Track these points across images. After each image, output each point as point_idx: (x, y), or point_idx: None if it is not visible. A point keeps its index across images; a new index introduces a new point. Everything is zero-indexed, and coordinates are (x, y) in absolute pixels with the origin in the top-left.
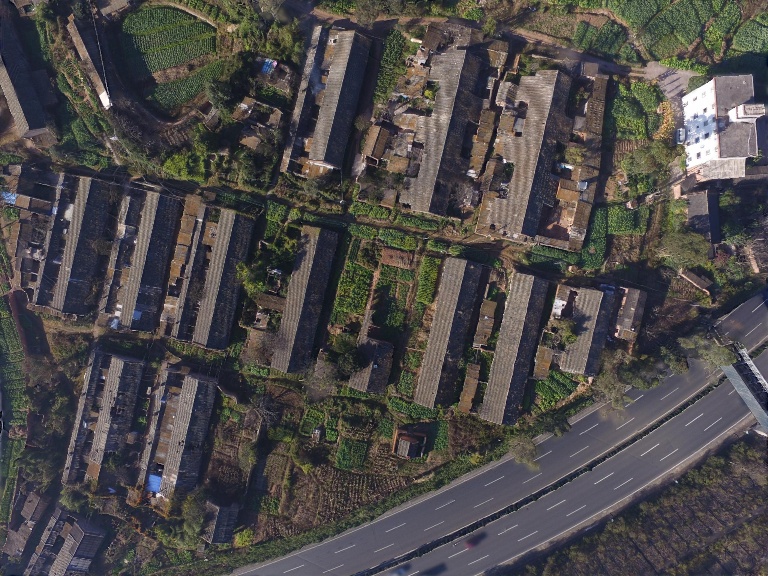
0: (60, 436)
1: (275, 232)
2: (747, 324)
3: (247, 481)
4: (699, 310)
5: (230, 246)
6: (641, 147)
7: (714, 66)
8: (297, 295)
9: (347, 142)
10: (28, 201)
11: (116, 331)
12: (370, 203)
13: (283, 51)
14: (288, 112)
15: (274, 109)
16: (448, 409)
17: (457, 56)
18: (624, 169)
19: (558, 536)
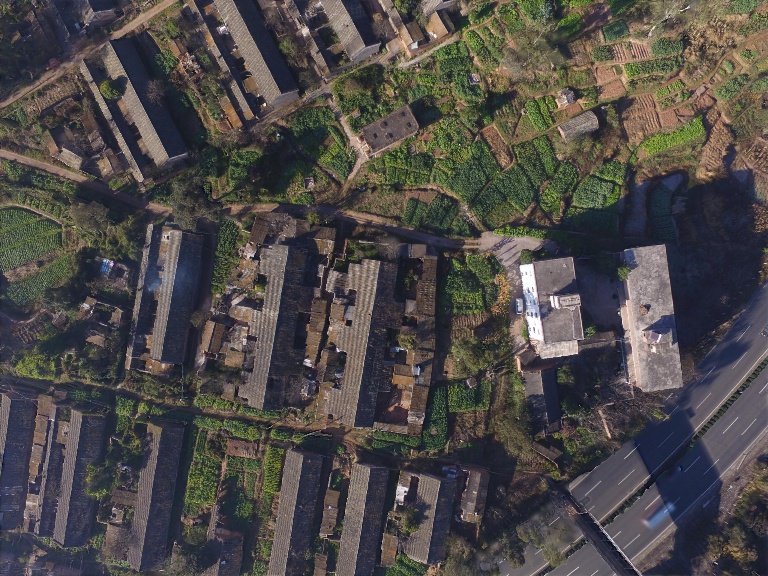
0: None
1: (126, 425)
2: (620, 471)
3: None
4: (551, 480)
5: (80, 447)
6: (461, 341)
7: (553, 228)
8: (145, 493)
9: (189, 333)
10: None
11: None
12: (211, 397)
13: (119, 250)
14: (129, 308)
15: (115, 307)
16: None
17: (281, 251)
18: (454, 355)
19: None
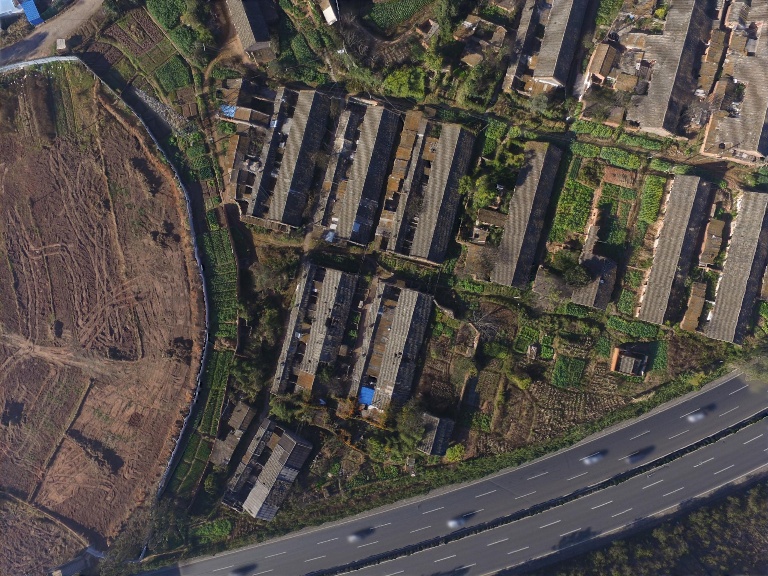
0: (269, 348)
1: (493, 150)
2: None
3: (462, 395)
4: None
5: (454, 160)
6: None
7: None
8: (522, 209)
9: None
10: (249, 113)
11: (331, 244)
12: (596, 120)
13: None
14: (511, 31)
15: (498, 27)
16: (668, 329)
17: None
18: None
19: (755, 470)
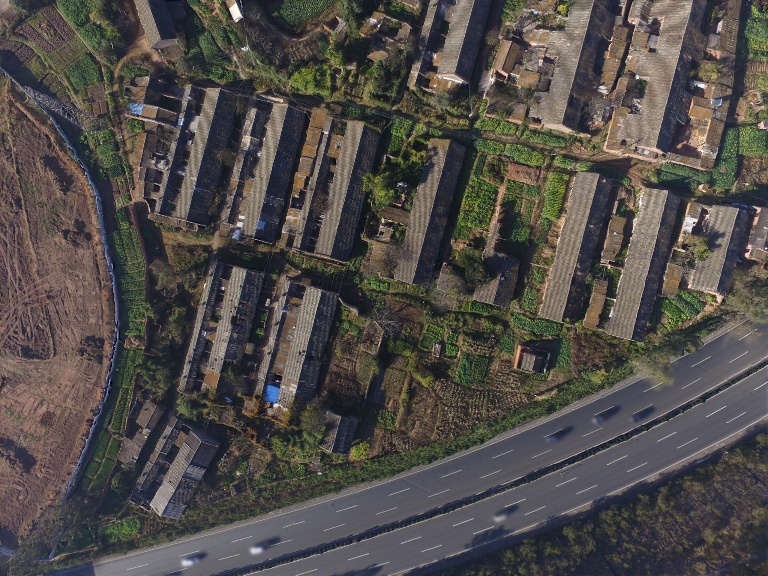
0: (177, 346)
1: (399, 147)
2: None
3: (366, 393)
4: None
5: (357, 157)
6: None
7: None
8: (424, 207)
9: None
10: (155, 111)
11: (238, 242)
12: (499, 117)
13: None
14: (416, 28)
15: (403, 24)
16: (571, 327)
17: None
18: (761, 86)
19: (669, 468)
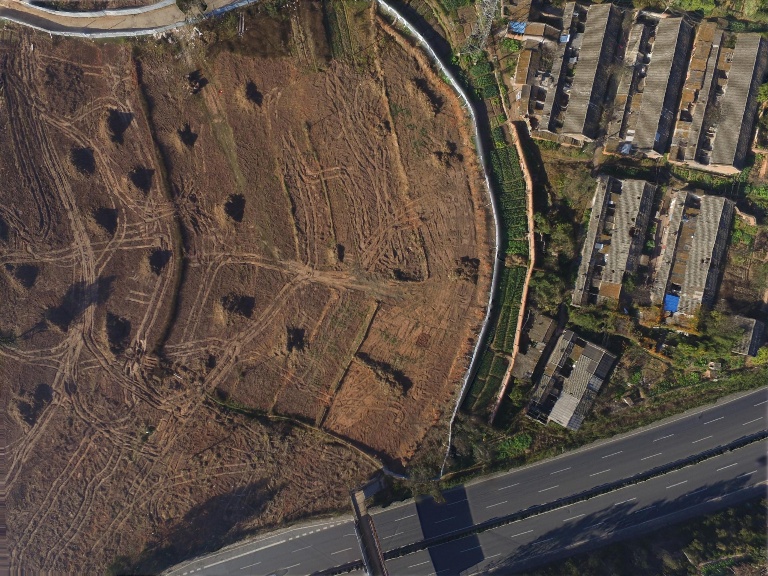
0: (565, 261)
1: None
2: None
3: (767, 298)
4: None
5: (754, 68)
6: None
7: None
8: None
9: None
10: (542, 28)
11: (628, 156)
12: None
13: None
14: None
15: None
16: None
17: None
18: None
19: None
